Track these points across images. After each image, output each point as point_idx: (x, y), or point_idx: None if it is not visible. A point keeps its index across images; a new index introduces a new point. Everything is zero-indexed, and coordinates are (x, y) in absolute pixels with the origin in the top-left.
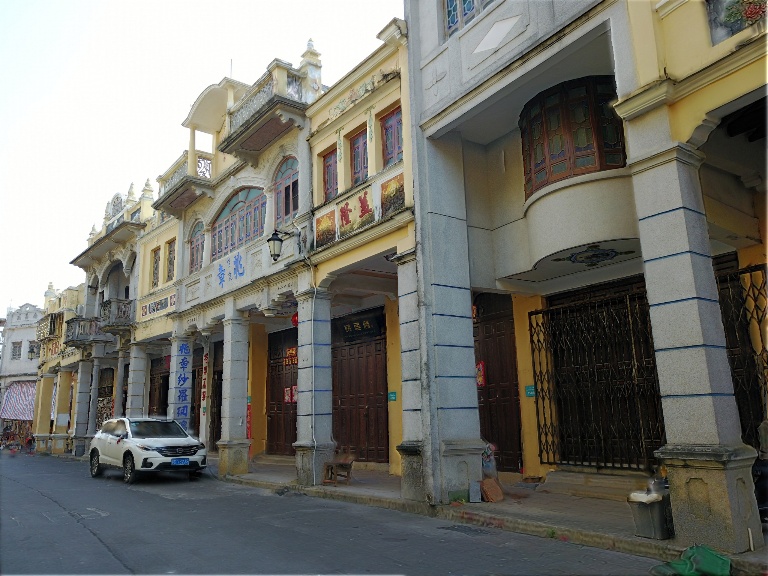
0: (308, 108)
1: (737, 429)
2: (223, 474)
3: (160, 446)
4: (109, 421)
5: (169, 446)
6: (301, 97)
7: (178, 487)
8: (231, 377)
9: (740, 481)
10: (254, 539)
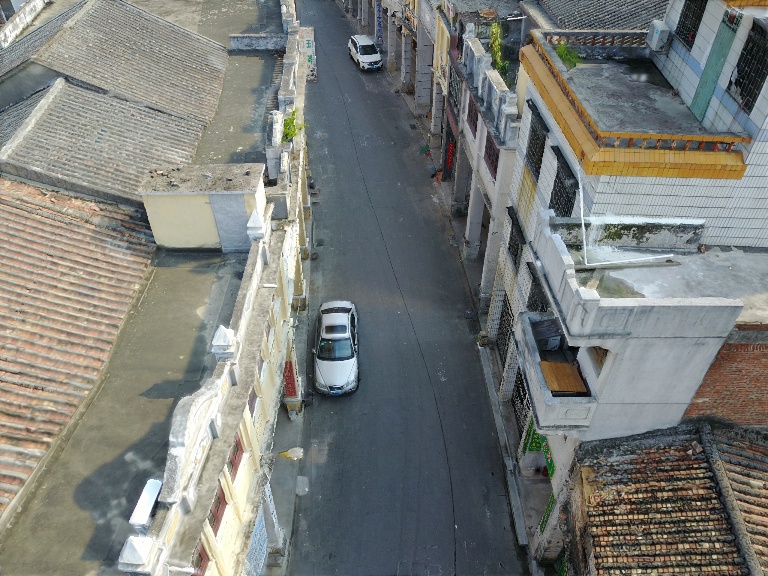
0: None
1: (440, 130)
2: (388, 70)
3: (367, 61)
4: (353, 39)
5: (370, 62)
6: None
7: (373, 76)
8: (390, 38)
9: (437, 138)
10: (373, 122)
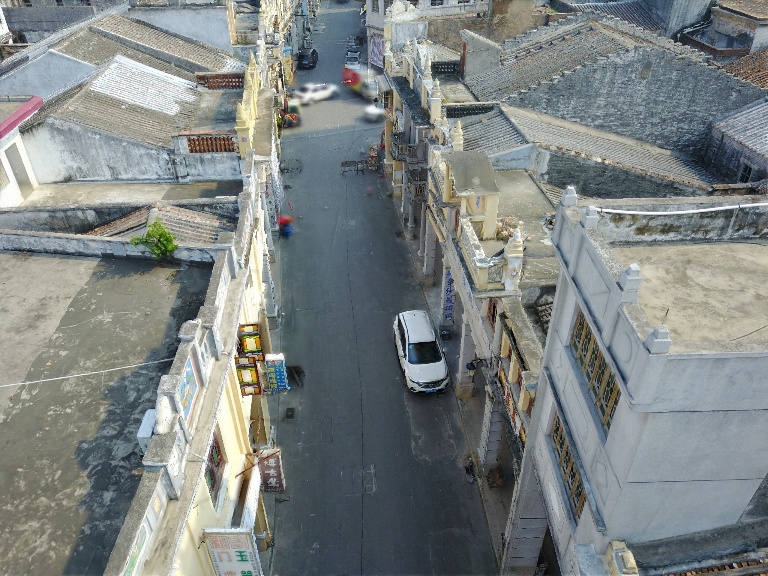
0: (501, 301)
1: None
2: (457, 395)
3: (420, 381)
4: (401, 322)
5: (425, 382)
6: (501, 277)
7: (428, 406)
8: (464, 354)
9: None
10: None
